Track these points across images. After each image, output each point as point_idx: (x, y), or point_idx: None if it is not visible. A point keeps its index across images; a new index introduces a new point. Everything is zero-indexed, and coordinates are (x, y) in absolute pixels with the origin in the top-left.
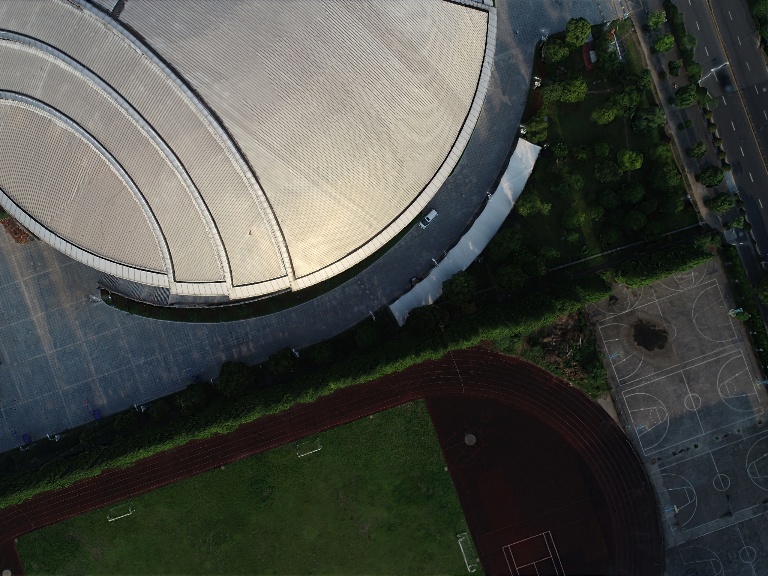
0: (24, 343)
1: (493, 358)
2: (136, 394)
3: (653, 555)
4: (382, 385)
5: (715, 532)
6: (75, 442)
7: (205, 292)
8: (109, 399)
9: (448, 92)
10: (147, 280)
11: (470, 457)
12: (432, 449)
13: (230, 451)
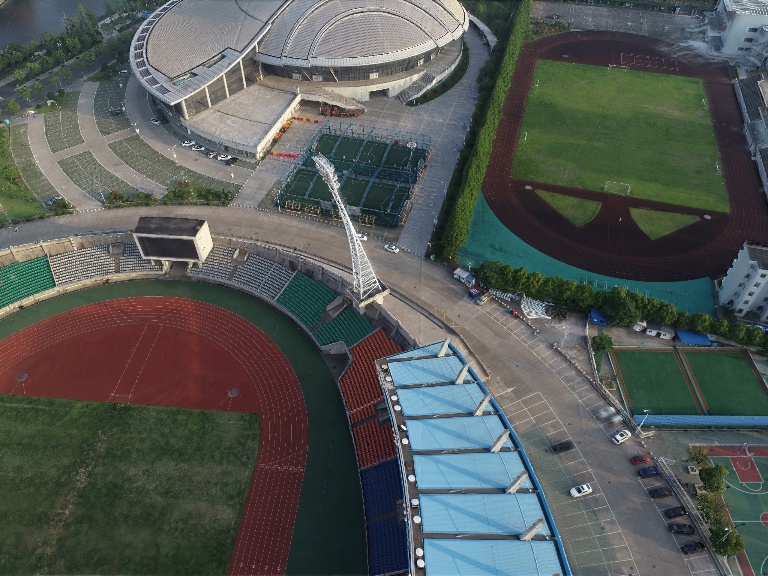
0: None
1: (533, 42)
2: None
3: (649, 39)
4: None
5: (647, 27)
6: (474, 137)
7: (447, 41)
8: (462, 122)
9: None
10: (428, 47)
11: None
12: None
13: (519, 104)
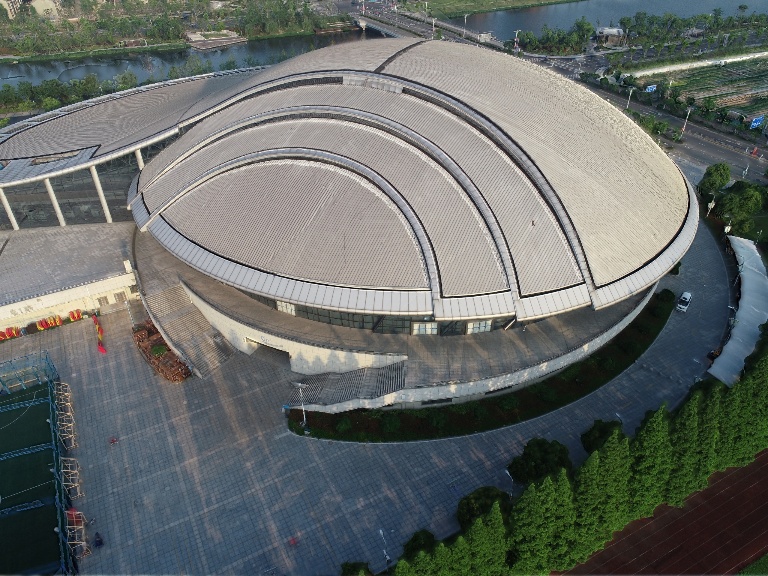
0: (153, 506)
1: None
2: (357, 561)
3: None
4: None
5: None
6: None
7: (483, 311)
8: None
9: None
10: (400, 306)
11: None
12: None
13: None
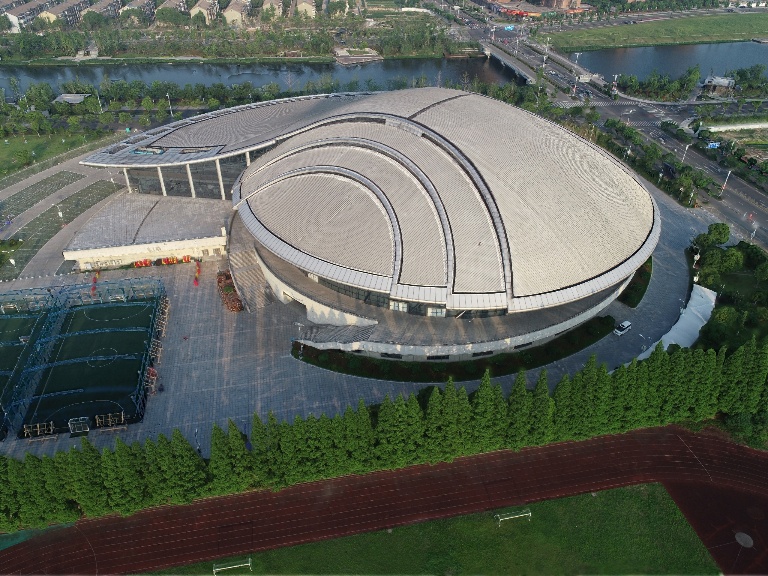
0: (196, 378)
1: (737, 450)
2: None
3: None
4: (601, 461)
5: None
6: None
7: (424, 297)
8: None
9: (634, 207)
10: (370, 284)
11: (753, 563)
12: (691, 544)
13: (402, 511)
